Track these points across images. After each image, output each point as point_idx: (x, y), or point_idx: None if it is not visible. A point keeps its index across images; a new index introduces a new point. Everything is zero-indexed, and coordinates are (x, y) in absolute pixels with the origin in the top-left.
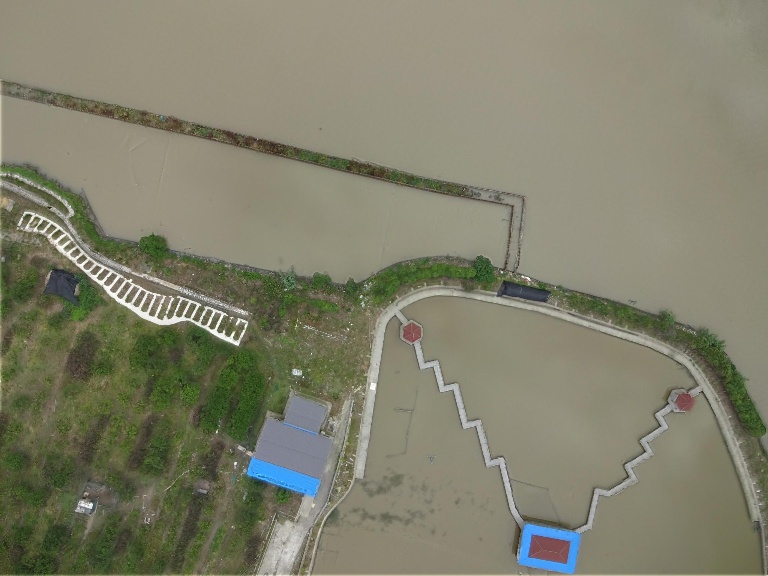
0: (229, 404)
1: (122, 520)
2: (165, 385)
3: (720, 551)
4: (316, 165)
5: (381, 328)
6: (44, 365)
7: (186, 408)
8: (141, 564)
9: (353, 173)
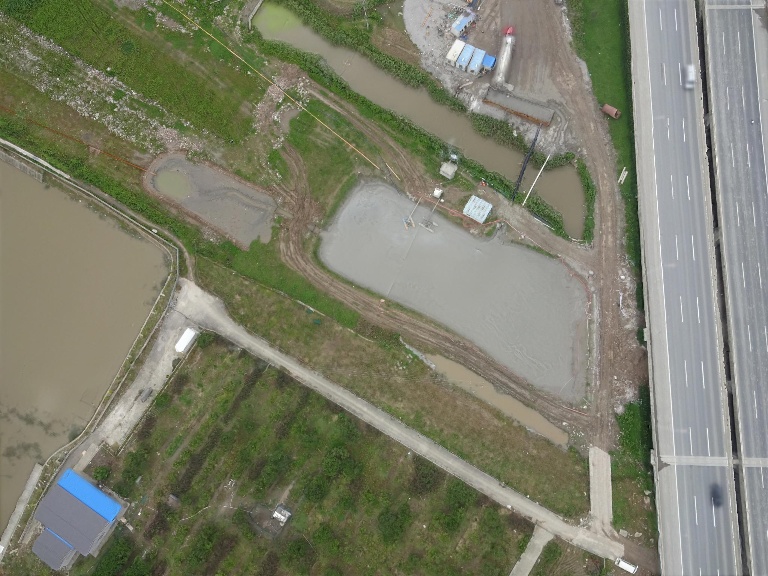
0: None
1: None
2: None
3: None
4: None
5: None
6: None
7: None
8: None
9: None
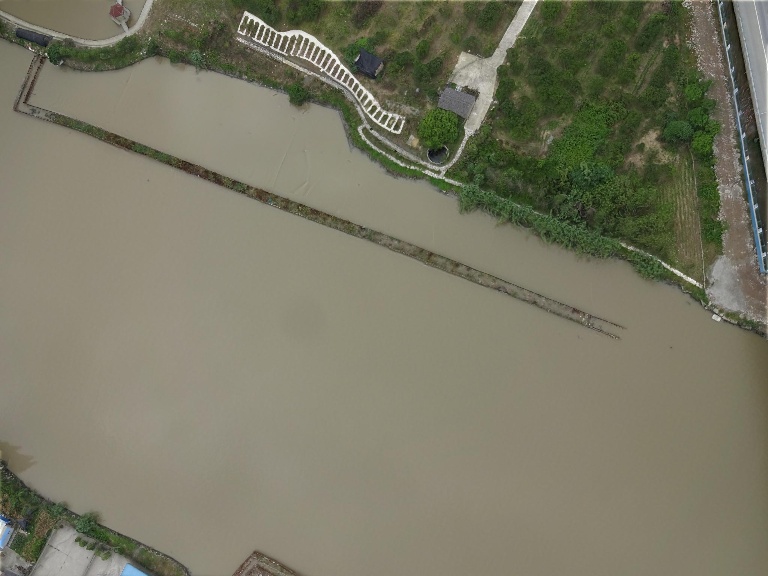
0: None
1: None
2: None
3: None
4: None
5: (142, 20)
6: (399, 7)
7: None
8: None
9: None
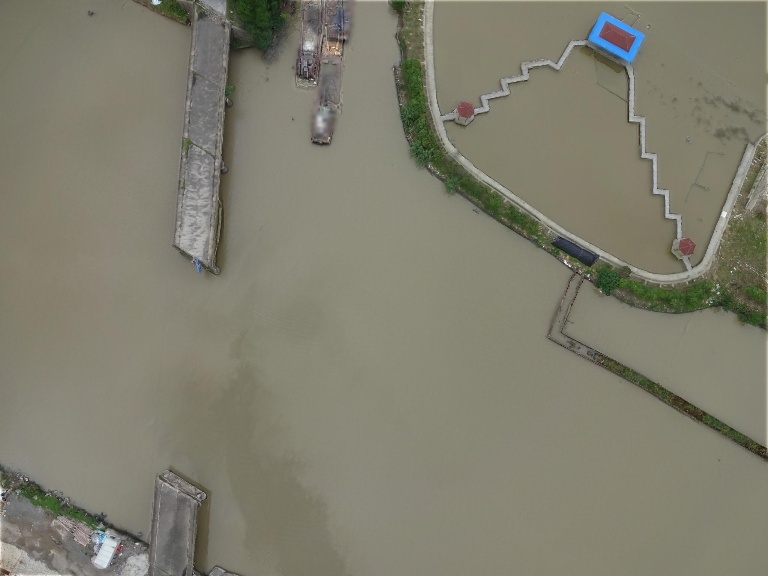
0: None
1: None
2: None
3: None
4: None
5: (706, 261)
6: None
7: None
8: None
9: None
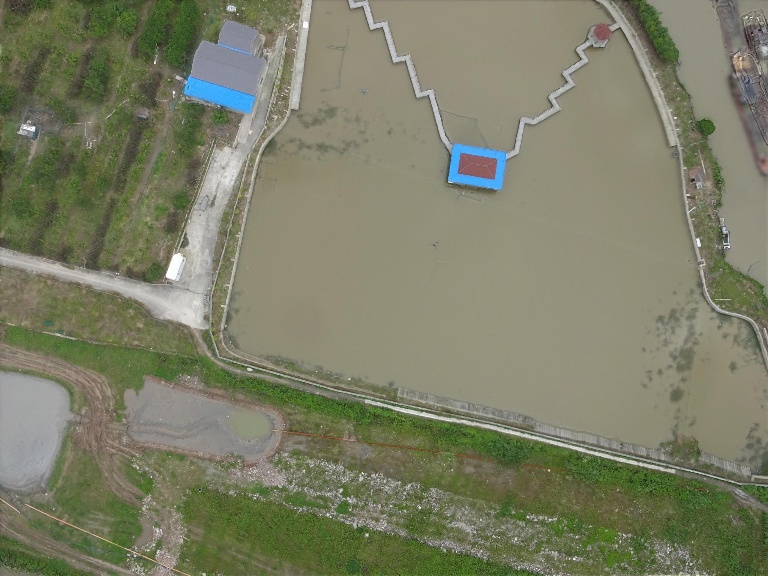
0: (165, 29)
1: (65, 145)
2: (102, 12)
3: (641, 173)
4: None
5: None
6: None
7: (124, 41)
8: (84, 186)
9: None
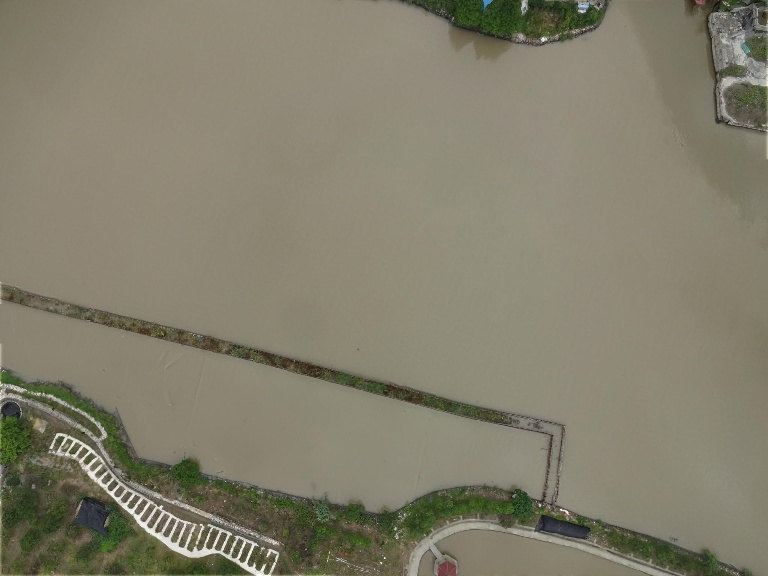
0: None
1: None
2: None
3: None
4: (353, 388)
5: (415, 562)
6: None
7: None
8: None
9: (390, 397)
